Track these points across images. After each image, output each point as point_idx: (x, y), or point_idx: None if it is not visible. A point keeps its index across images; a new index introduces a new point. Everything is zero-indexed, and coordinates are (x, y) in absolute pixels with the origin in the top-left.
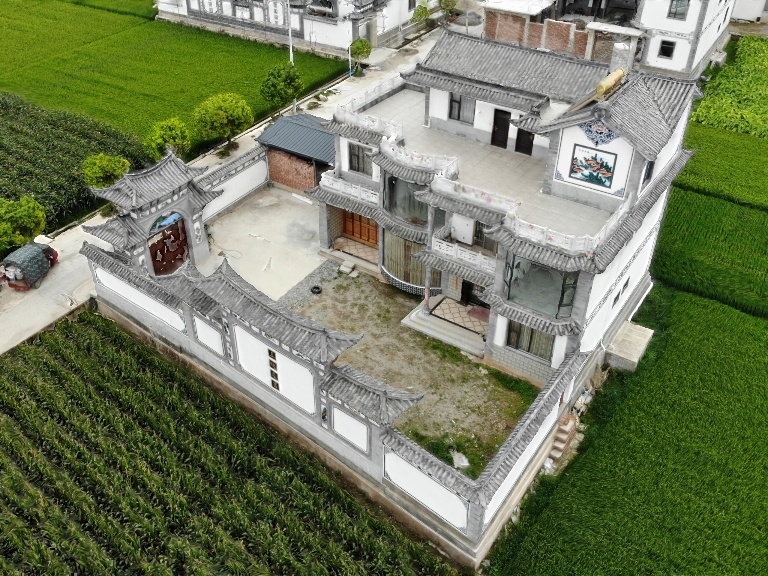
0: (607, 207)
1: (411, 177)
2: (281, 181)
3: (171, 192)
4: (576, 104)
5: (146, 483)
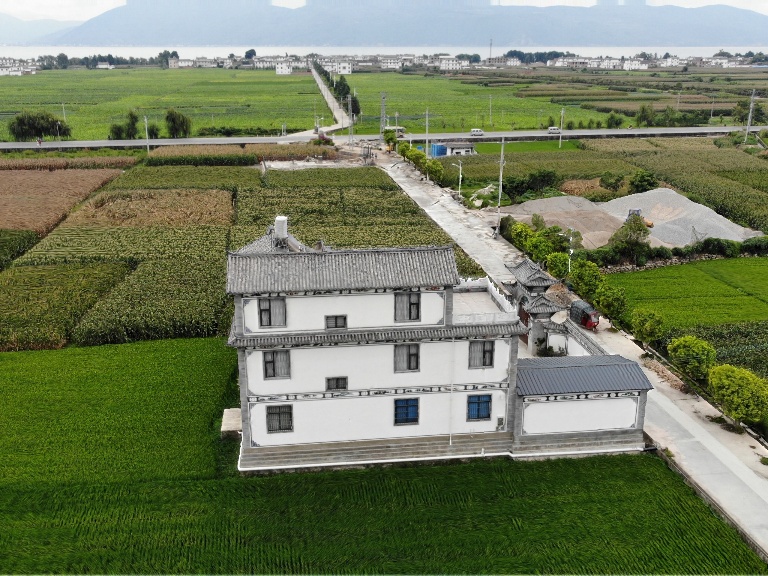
0: None
1: None
2: None
3: None
4: None
5: None
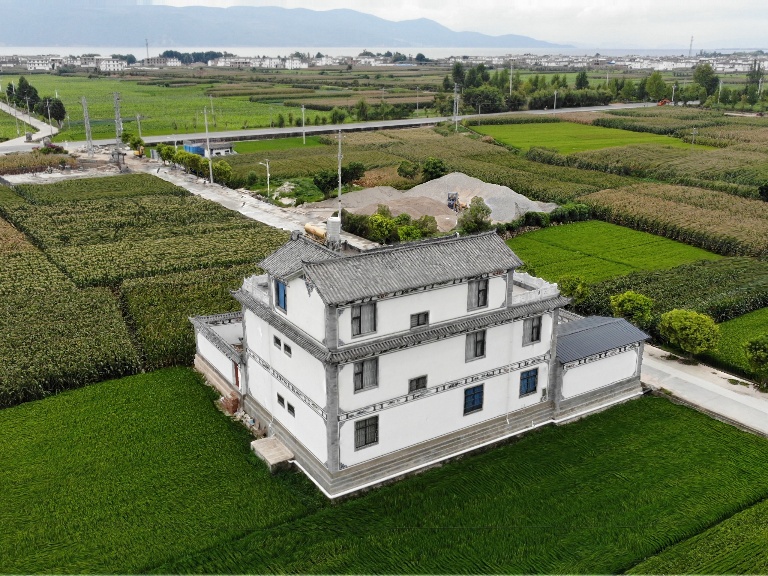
0: None
1: None
2: None
3: None
4: None
5: None
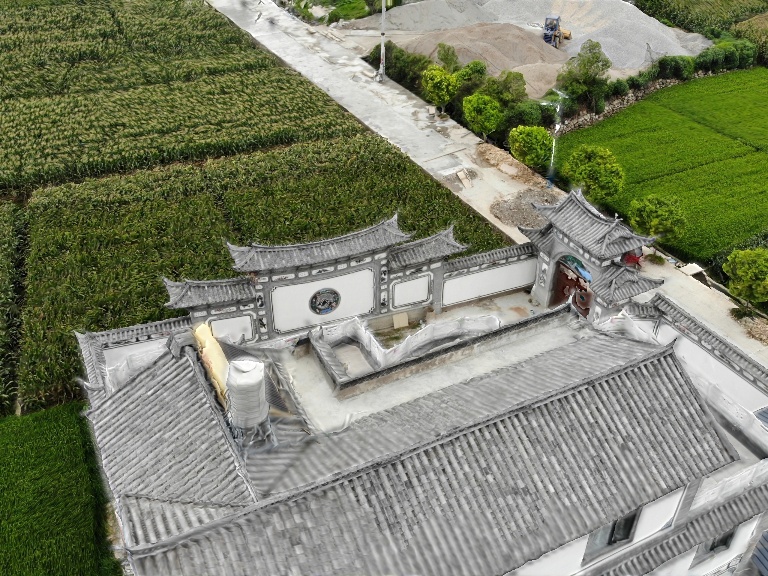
0: None
1: None
2: None
3: None
4: None
5: None
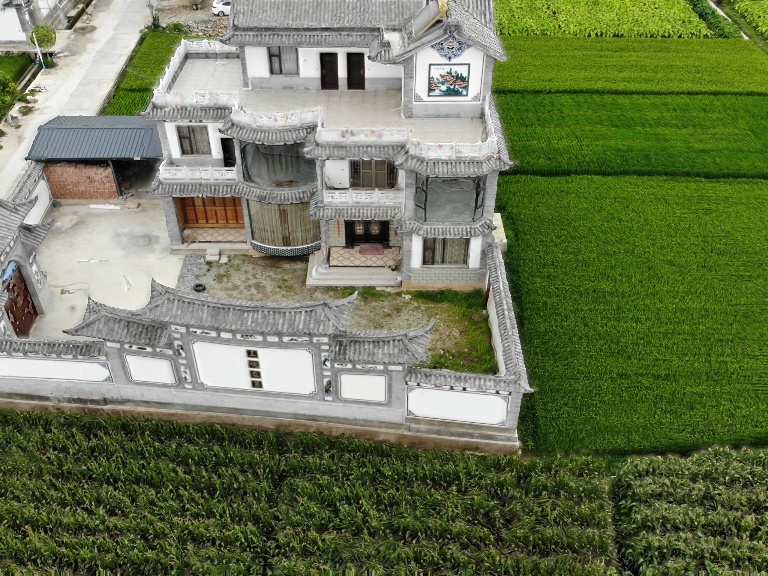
0: (467, 114)
1: (282, 139)
2: (69, 196)
3: None
4: (421, 27)
5: (200, 534)
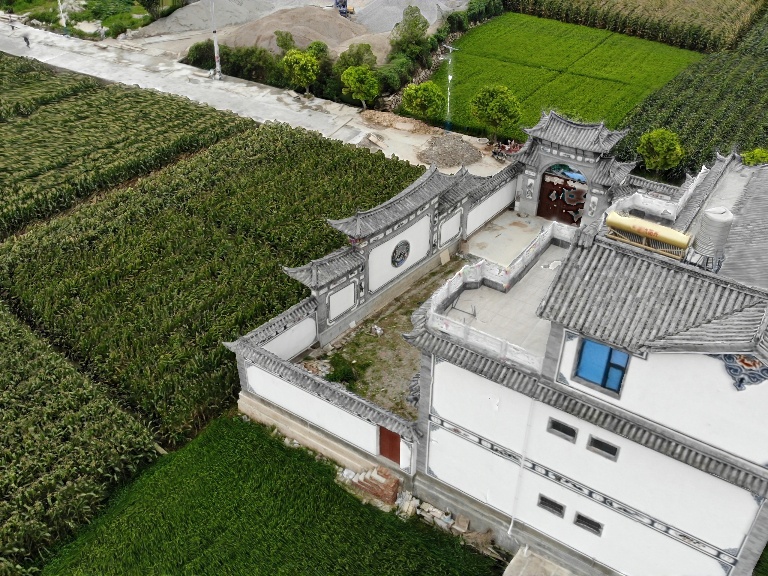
0: None
1: None
2: None
3: (575, 150)
4: None
5: None
